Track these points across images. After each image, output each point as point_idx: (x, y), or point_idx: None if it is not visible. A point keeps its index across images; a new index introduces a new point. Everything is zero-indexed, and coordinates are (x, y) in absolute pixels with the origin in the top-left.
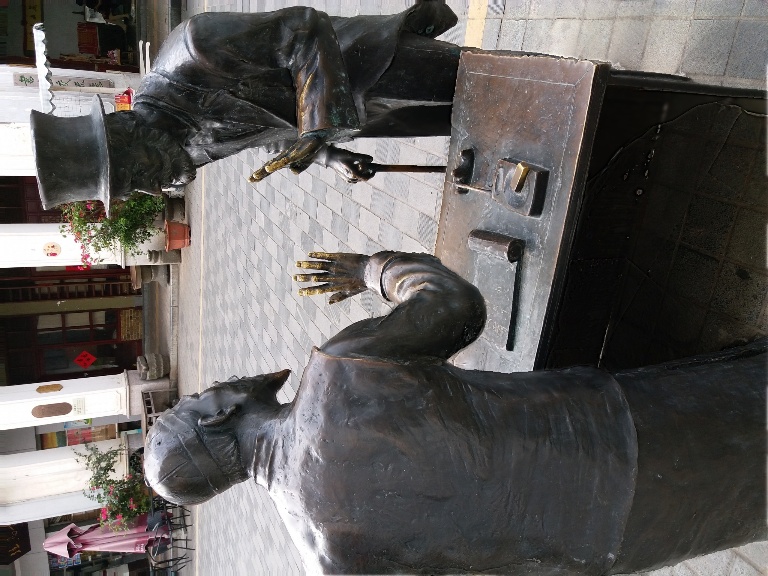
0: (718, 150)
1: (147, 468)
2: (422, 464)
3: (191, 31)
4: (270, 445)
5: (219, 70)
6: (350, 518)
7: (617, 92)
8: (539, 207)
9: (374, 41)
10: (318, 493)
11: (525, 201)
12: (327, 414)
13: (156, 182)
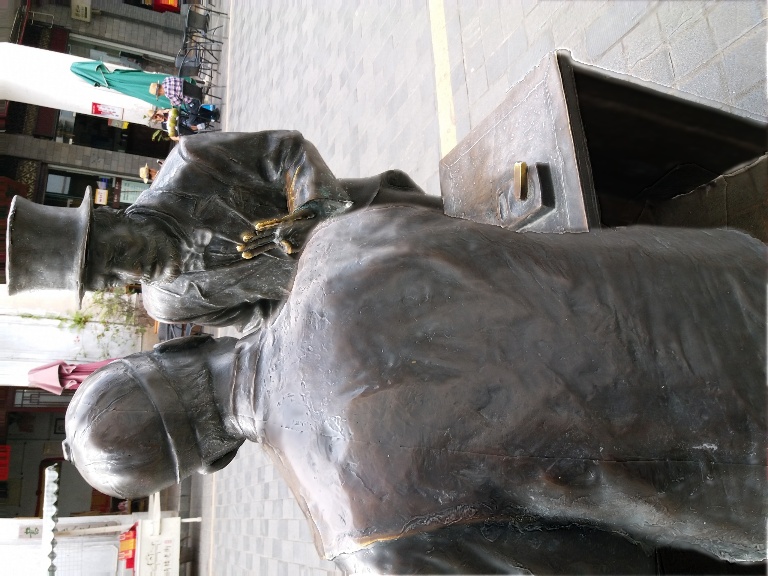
0: (724, 225)
1: (72, 423)
2: (473, 286)
3: (184, 141)
4: (256, 353)
5: (210, 167)
6: (381, 383)
7: (585, 74)
8: (550, 196)
9: (359, 181)
10: (328, 371)
11: (534, 197)
12: (330, 266)
13: (139, 265)
